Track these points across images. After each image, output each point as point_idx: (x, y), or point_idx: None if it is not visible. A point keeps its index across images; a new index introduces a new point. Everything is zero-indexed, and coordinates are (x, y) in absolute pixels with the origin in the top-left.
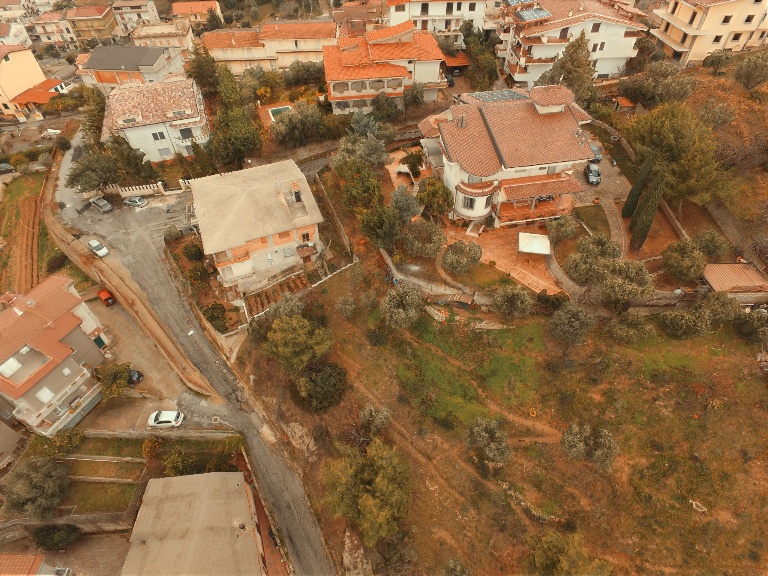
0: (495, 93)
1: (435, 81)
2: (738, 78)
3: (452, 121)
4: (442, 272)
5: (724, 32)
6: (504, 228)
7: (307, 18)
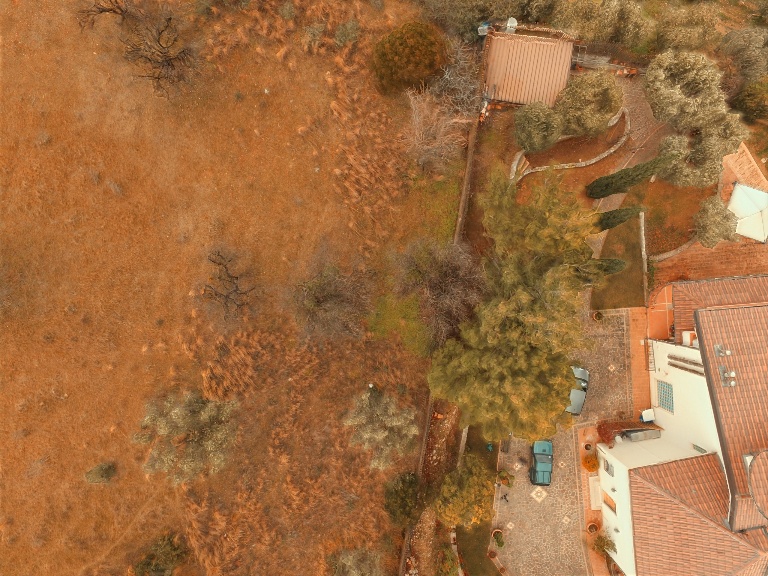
0: None
1: None
2: None
3: None
4: None
5: None
6: None
7: None
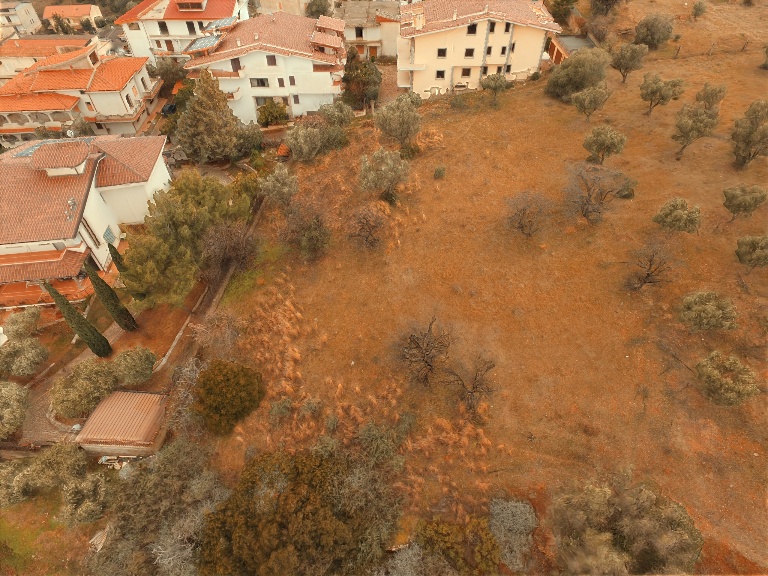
0: None
1: (118, 114)
2: (382, 130)
3: None
4: None
5: (445, 67)
6: (15, 311)
7: (69, 33)
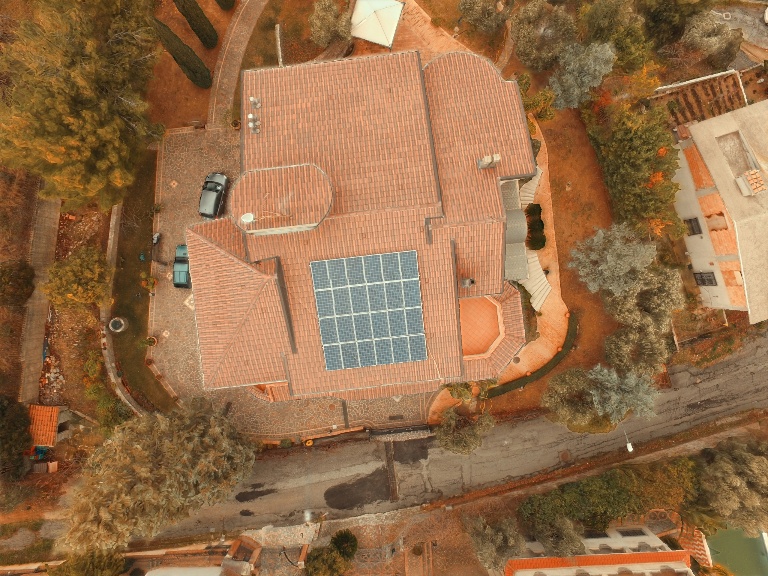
0: (369, 341)
1: None
2: None
3: (506, 177)
4: (508, 20)
5: None
6: None
7: None
